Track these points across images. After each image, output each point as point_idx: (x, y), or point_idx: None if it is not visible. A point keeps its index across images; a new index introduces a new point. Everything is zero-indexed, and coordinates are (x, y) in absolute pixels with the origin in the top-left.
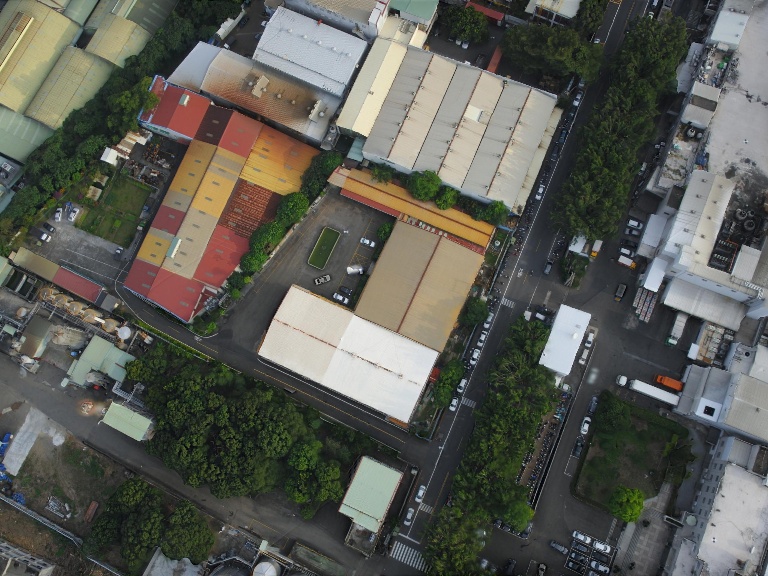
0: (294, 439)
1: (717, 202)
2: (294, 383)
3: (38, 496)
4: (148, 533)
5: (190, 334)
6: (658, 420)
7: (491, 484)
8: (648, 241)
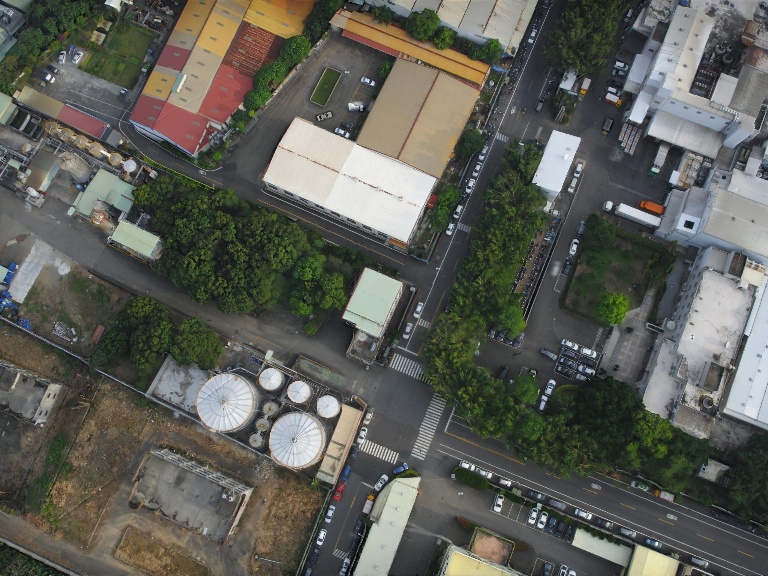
0: (299, 253)
1: (698, 35)
2: (297, 212)
3: (44, 322)
4: (158, 338)
5: (195, 168)
6: (641, 239)
7: (486, 292)
8: (634, 78)
